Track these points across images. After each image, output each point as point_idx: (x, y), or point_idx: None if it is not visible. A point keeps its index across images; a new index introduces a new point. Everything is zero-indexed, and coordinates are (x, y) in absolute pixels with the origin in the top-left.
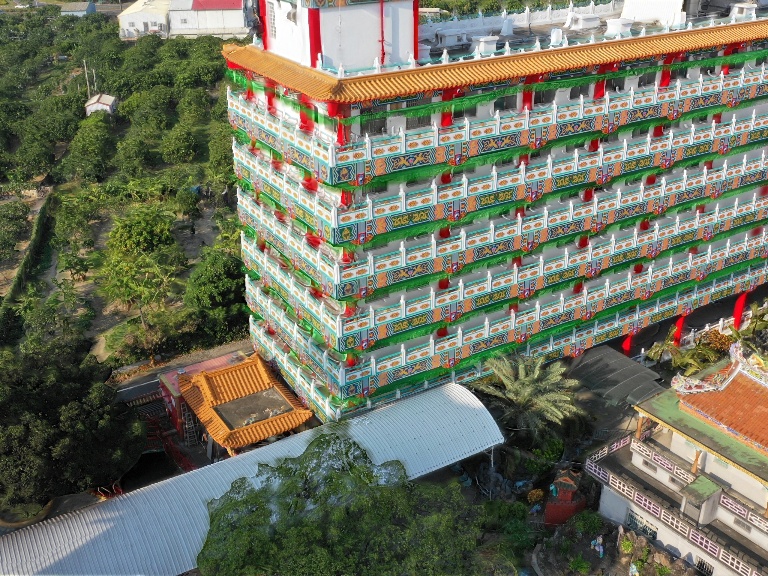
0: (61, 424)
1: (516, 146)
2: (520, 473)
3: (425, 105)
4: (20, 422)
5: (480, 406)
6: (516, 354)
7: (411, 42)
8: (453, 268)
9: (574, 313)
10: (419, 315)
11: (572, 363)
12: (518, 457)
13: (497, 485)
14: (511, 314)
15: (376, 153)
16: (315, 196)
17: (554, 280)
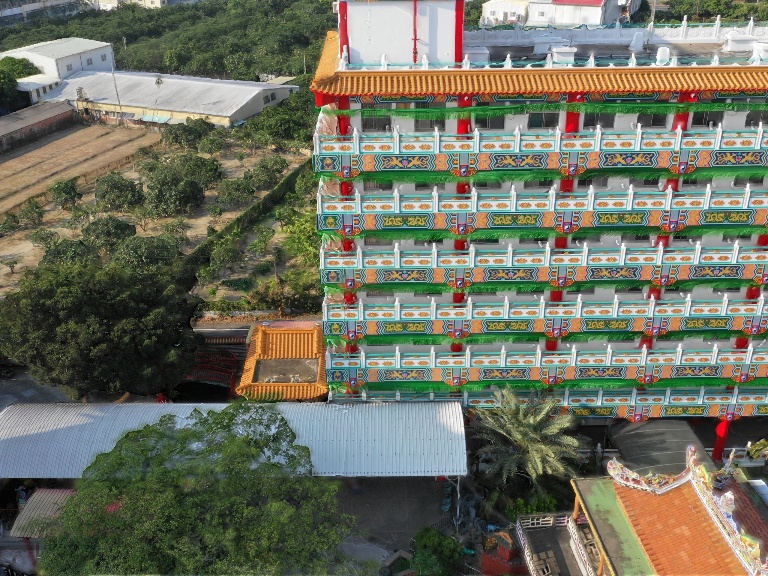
0: (112, 332)
1: (542, 168)
2: (508, 519)
3: (437, 109)
4: (85, 322)
5: (460, 432)
6: (539, 394)
7: (452, 44)
8: (458, 283)
9: (626, 371)
10: (416, 322)
11: (625, 427)
12: (493, 499)
13: (470, 520)
14: (537, 350)
15: (365, 149)
16: (329, 182)
17: (596, 326)
